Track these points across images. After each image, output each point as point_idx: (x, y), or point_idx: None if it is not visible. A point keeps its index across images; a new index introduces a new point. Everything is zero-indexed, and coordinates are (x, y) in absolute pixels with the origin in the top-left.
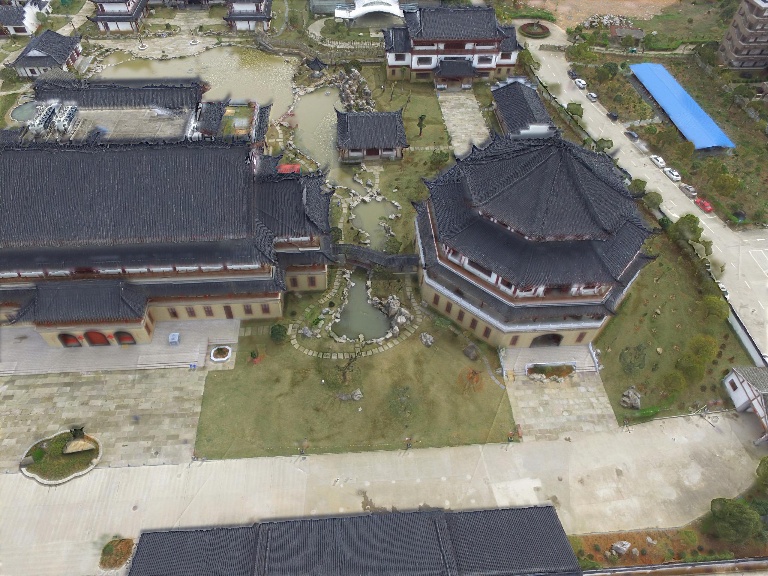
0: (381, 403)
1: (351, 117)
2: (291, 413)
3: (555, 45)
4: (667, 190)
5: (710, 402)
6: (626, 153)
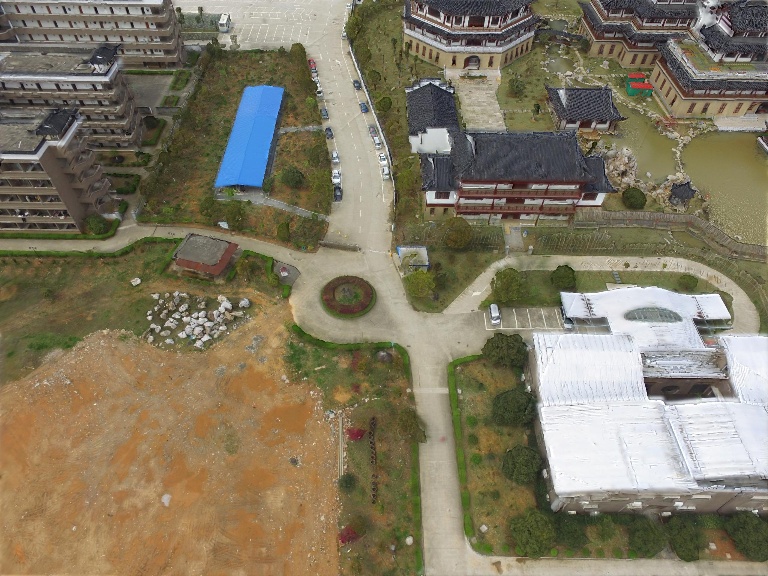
0: (537, 5)
1: (606, 90)
2: (576, 4)
3: (336, 243)
4: (329, 76)
5: (386, 1)
6: (340, 103)
